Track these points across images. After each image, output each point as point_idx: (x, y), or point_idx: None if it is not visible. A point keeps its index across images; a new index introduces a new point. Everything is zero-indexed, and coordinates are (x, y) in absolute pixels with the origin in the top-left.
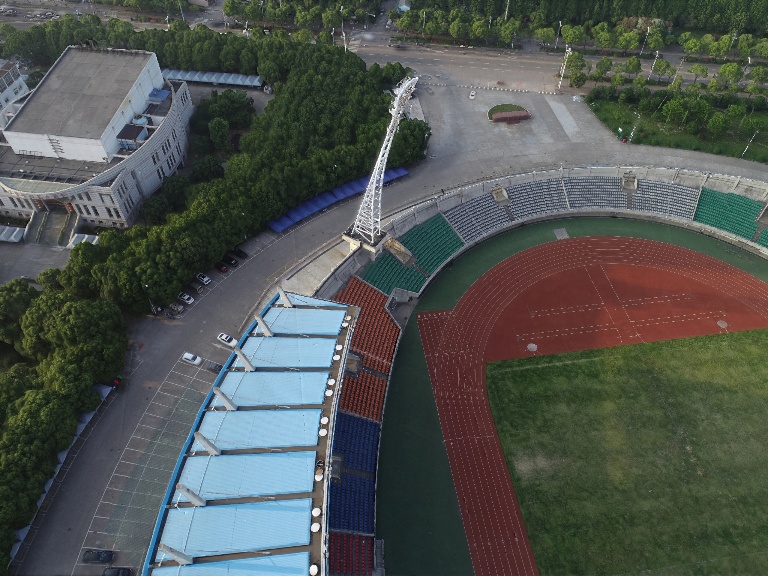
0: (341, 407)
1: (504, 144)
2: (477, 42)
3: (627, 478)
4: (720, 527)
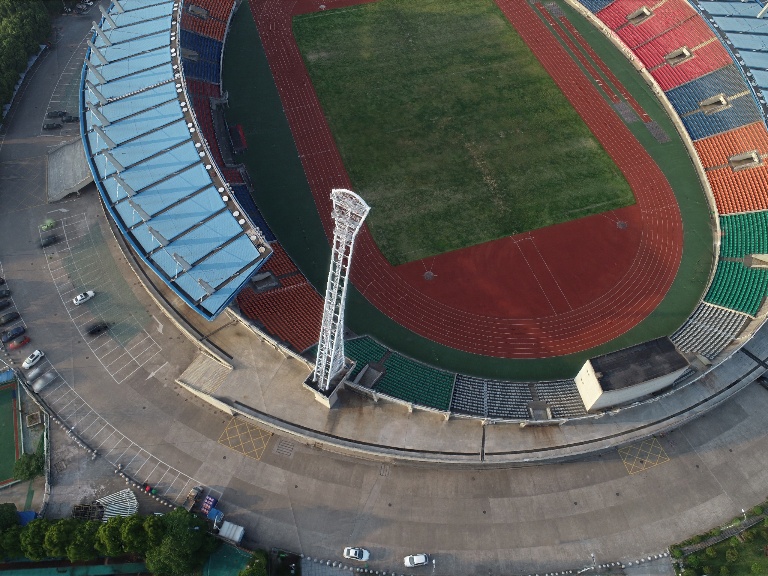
0: None
1: None
2: None
3: (372, 55)
4: (421, 68)
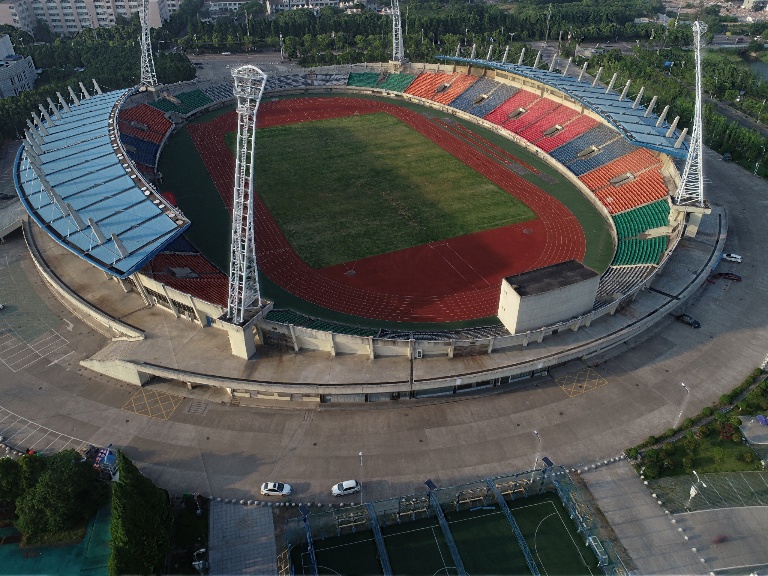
0: None
1: None
2: (233, 50)
3: (295, 150)
4: None
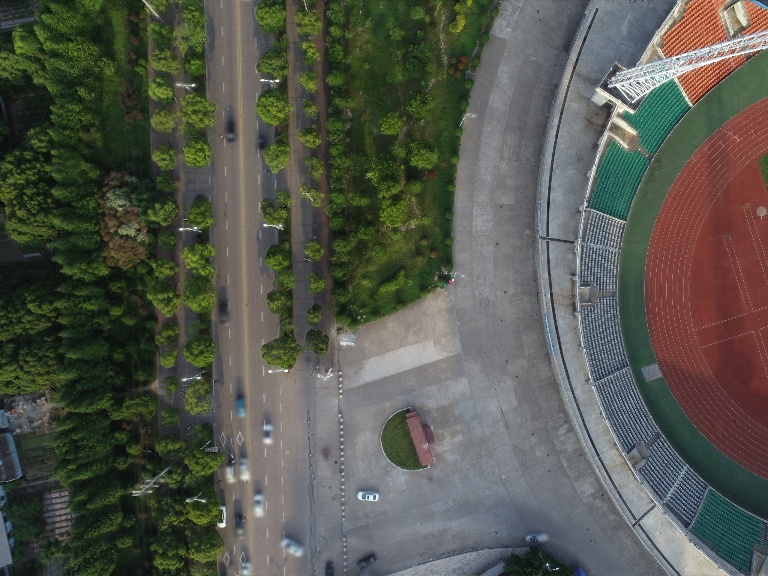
0: None
1: (483, 445)
2: None
3: None
4: None
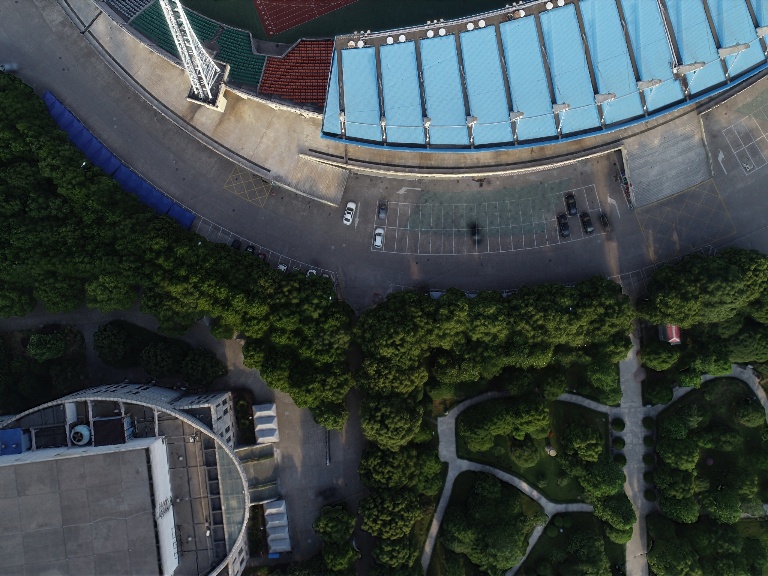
0: None
1: None
2: None
3: None
4: None
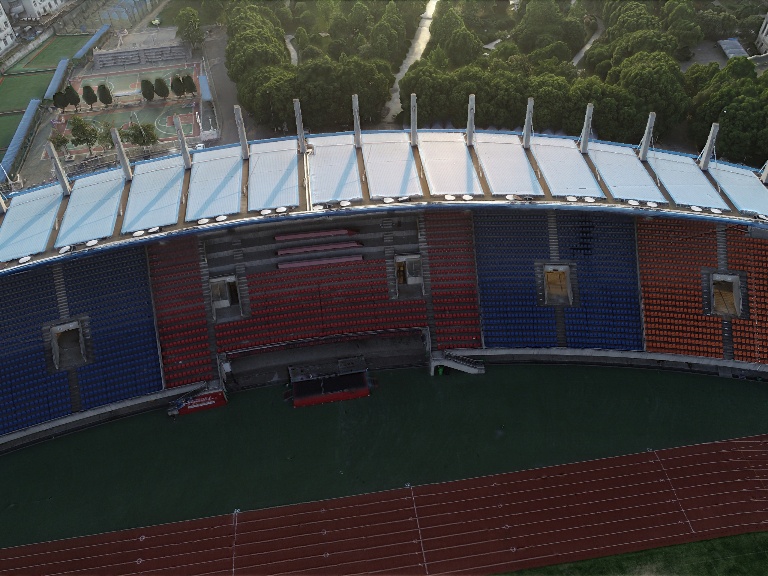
0: (647, 295)
1: None
2: None
3: None
4: None
